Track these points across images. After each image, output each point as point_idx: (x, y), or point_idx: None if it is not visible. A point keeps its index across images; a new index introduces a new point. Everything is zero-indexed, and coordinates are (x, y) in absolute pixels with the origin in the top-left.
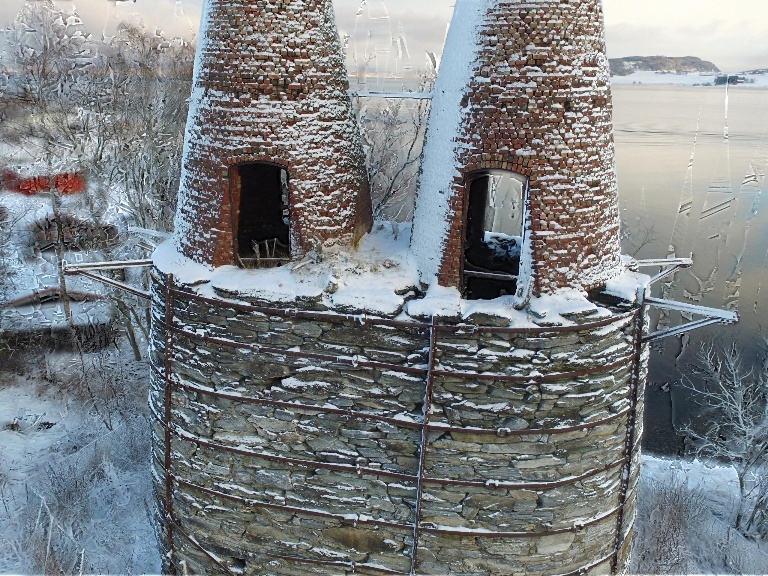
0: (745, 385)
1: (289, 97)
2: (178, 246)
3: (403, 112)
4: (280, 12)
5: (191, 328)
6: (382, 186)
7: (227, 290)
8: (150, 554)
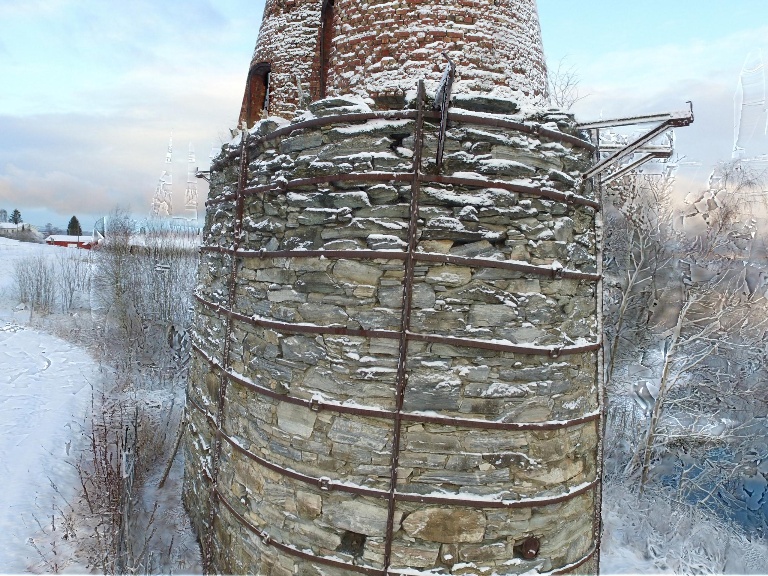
0: None
1: (285, 11)
2: None
3: (761, 164)
4: None
5: None
6: (741, 263)
7: None
8: None
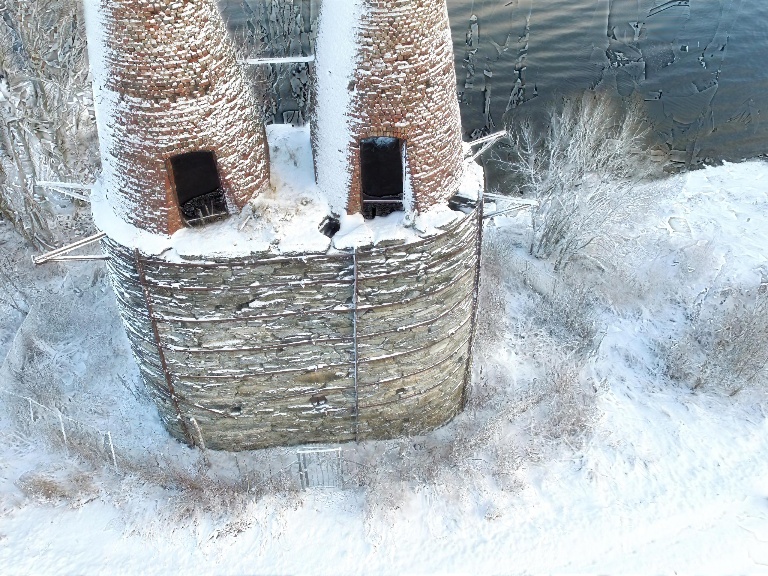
0: (536, 151)
1: (202, 94)
2: (125, 218)
3: None
4: (176, 21)
5: (166, 283)
6: None
7: (193, 256)
8: (135, 408)
